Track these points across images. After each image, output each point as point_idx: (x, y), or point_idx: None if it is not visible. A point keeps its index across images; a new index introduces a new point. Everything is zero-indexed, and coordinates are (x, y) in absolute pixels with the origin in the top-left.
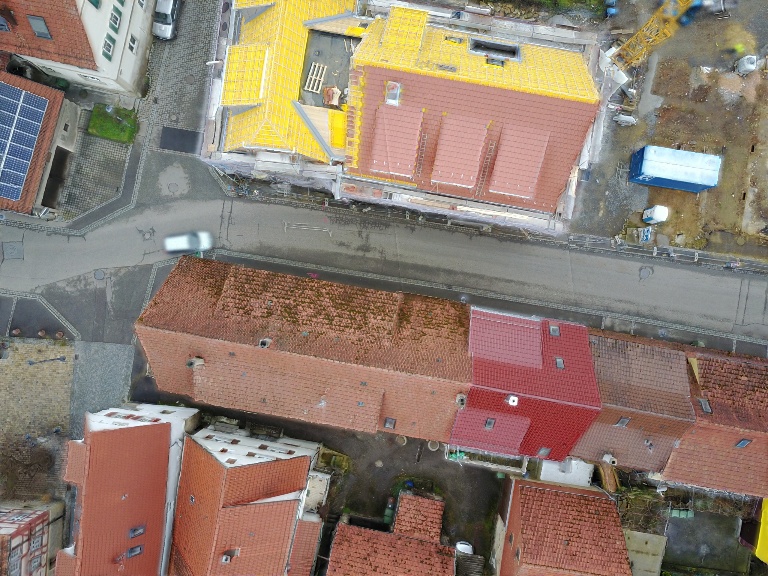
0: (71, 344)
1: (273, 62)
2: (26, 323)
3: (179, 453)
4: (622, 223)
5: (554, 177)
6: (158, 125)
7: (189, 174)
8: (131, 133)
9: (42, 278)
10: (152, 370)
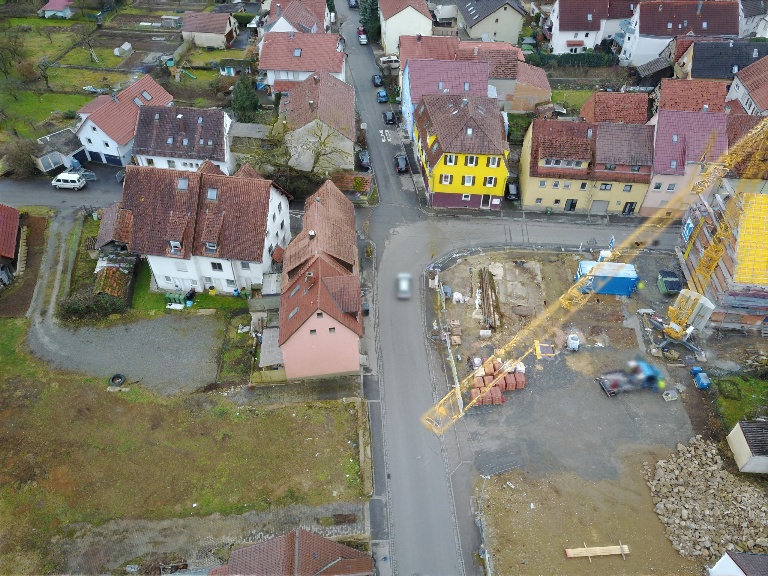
0: None
1: None
2: None
3: None
4: None
5: None
6: None
7: None
8: None
9: None
10: None
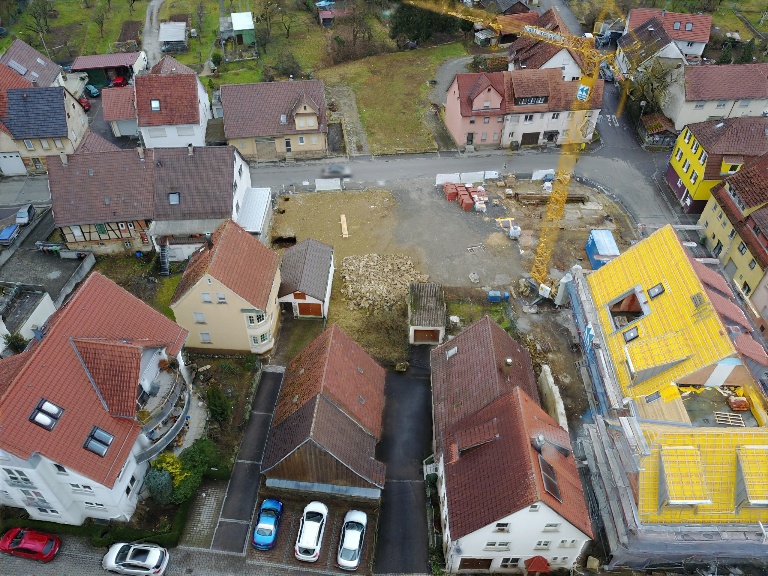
0: None
1: (759, 433)
2: None
3: None
4: None
5: None
6: None
7: None
8: None
9: None
10: None
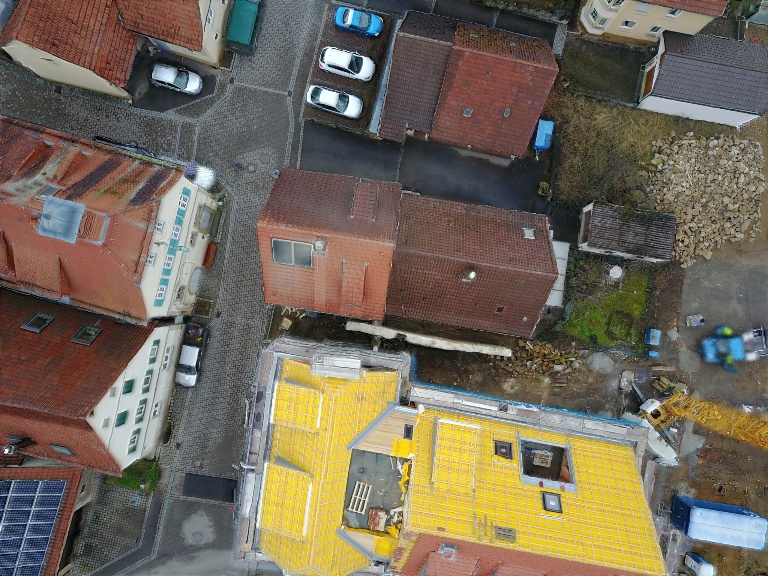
0: None
1: (318, 505)
2: None
3: None
4: None
5: None
6: (180, 472)
7: (214, 522)
8: (152, 483)
9: None
10: None
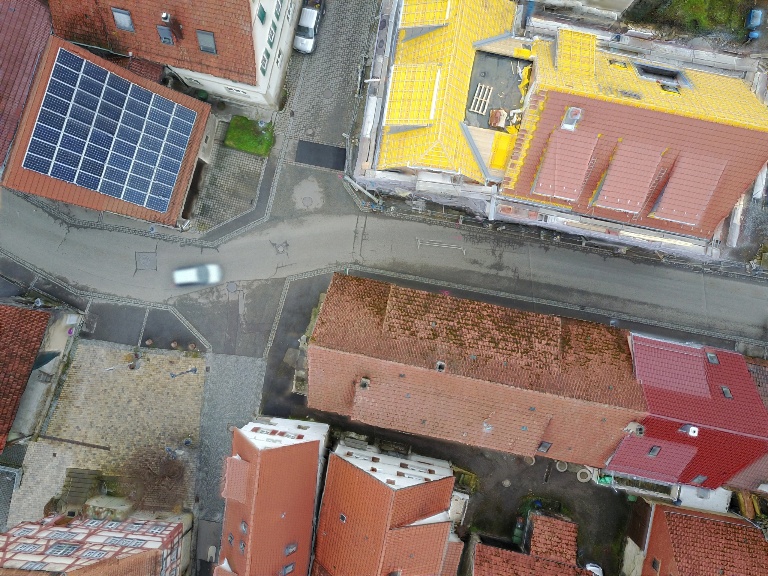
0: (202, 356)
1: (447, 83)
2: (158, 334)
3: (321, 470)
4: (757, 248)
5: (719, 205)
6: (294, 138)
7: (324, 188)
8: (268, 146)
9: (175, 289)
10: (308, 388)
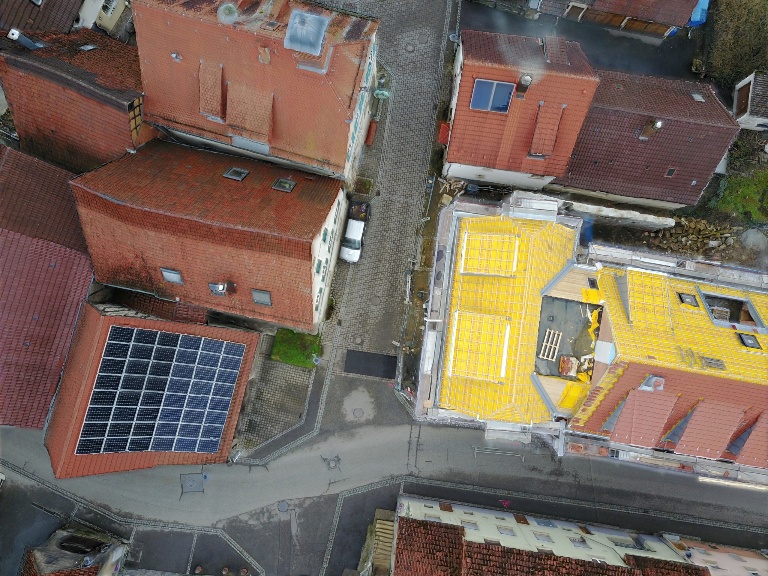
0: None
1: (520, 343)
2: (207, 560)
3: None
4: None
5: None
6: (342, 348)
7: (375, 398)
8: None
9: (223, 511)
10: None
